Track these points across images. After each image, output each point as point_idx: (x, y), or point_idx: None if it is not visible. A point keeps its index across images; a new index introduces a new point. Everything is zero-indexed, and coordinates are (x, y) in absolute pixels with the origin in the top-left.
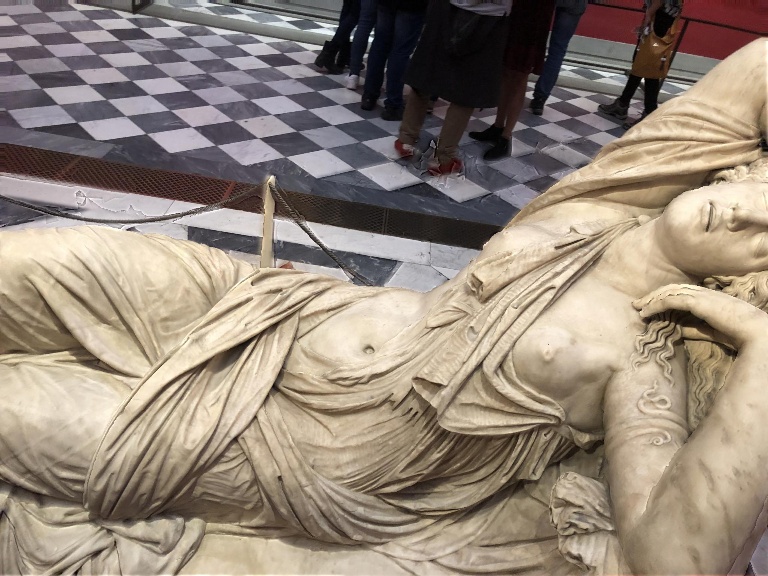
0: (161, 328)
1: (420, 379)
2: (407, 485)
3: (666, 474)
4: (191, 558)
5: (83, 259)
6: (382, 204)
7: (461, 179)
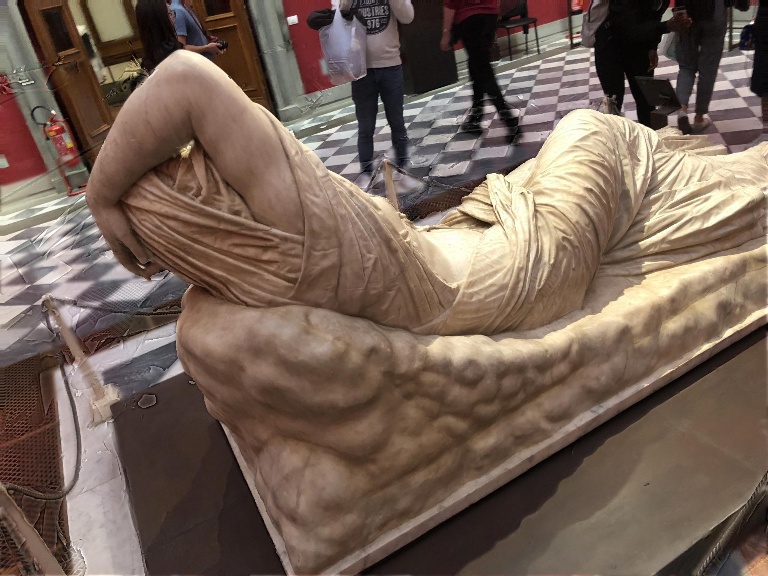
0: None
1: None
2: None
3: None
4: None
5: None
6: None
7: None
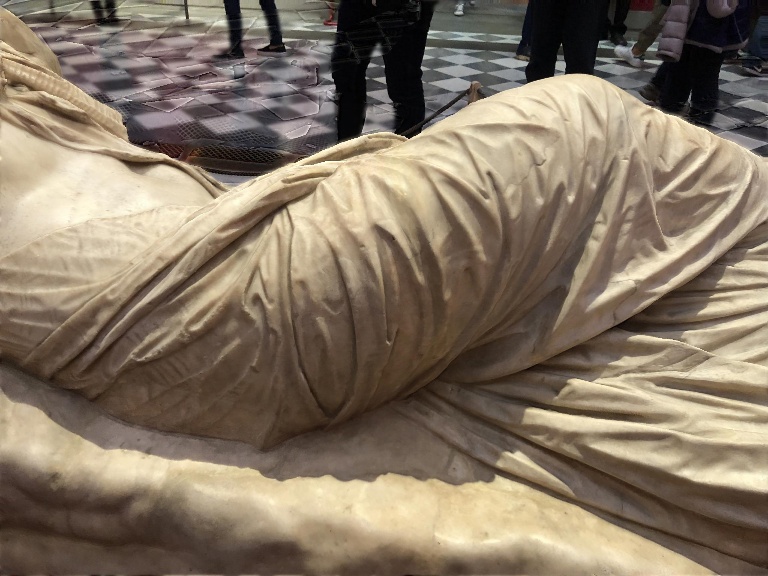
0: None
1: None
2: None
3: (7, 34)
4: None
5: None
6: None
7: None
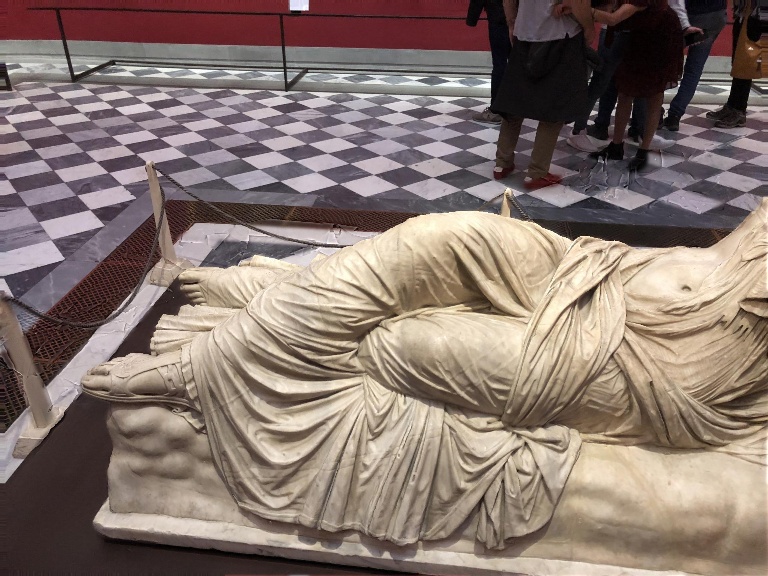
0: (527, 282)
1: (747, 301)
2: (740, 394)
3: None
4: (578, 457)
5: (478, 230)
6: (559, 219)
7: (626, 190)
